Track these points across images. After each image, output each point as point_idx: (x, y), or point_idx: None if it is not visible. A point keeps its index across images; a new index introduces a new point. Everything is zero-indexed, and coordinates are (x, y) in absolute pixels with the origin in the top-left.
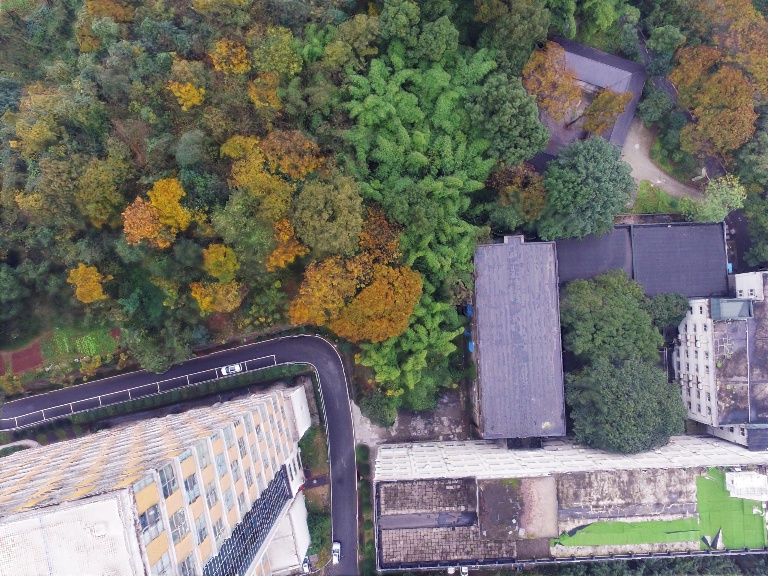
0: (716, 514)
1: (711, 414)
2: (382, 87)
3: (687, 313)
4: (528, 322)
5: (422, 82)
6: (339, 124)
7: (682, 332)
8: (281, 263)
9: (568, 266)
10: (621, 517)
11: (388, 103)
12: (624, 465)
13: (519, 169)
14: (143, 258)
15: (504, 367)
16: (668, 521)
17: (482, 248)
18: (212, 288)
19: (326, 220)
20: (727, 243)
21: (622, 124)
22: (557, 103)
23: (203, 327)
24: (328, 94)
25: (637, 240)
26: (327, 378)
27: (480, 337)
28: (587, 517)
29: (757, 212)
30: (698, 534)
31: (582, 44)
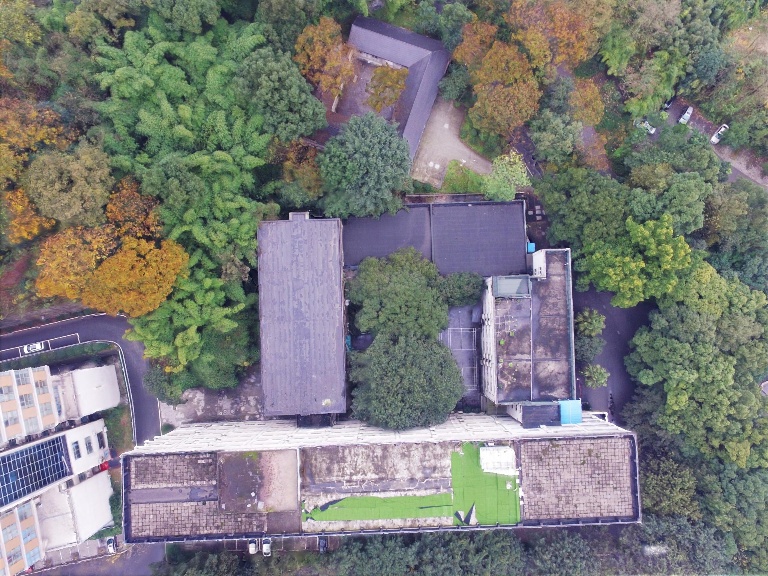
0: (470, 489)
1: None
2: (139, 59)
3: (486, 292)
4: (311, 299)
5: (186, 55)
6: (85, 95)
7: (484, 312)
8: (22, 234)
9: (367, 245)
10: (374, 492)
11: (145, 75)
12: (380, 440)
13: (292, 144)
14: None
15: (285, 344)
16: (421, 496)
17: (266, 224)
18: None
19: (59, 190)
20: (538, 223)
21: (423, 103)
22: (328, 78)
23: None
24: (79, 65)
25: (437, 219)
26: (132, 357)
27: (262, 314)
28: (340, 492)
29: (543, 190)
30: (451, 509)
31: (387, 23)
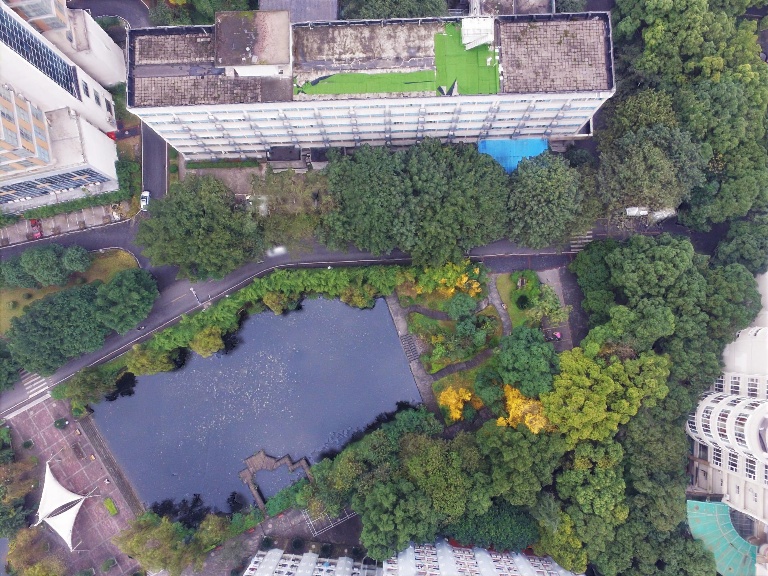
0: (452, 67)
1: None
2: None
3: None
4: None
5: None
6: None
7: None
8: None
9: None
10: (362, 69)
11: None
12: None
13: None
14: None
15: None
16: (406, 72)
17: None
18: None
19: None
20: None
21: None
22: None
23: None
24: None
25: None
26: None
27: None
28: (330, 69)
29: None
30: (434, 84)
31: None
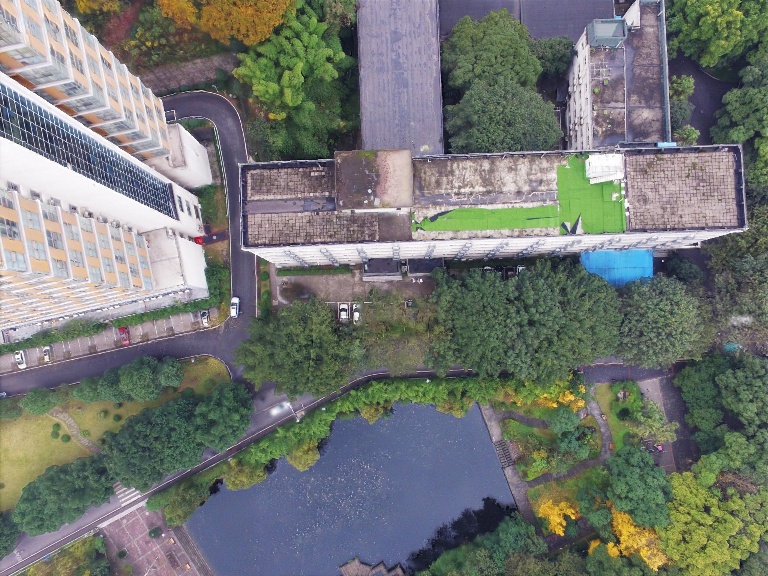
0: (576, 201)
1: (589, 140)
2: None
3: (574, 60)
4: (408, 50)
5: None
6: None
7: (571, 83)
8: None
9: (457, 15)
10: (482, 204)
11: None
12: None
13: None
14: None
15: (384, 93)
16: (528, 208)
17: None
18: None
19: None
20: (621, 6)
21: None
22: None
23: None
24: None
25: None
26: (226, 134)
27: (361, 64)
28: (449, 204)
29: None
30: (558, 220)
31: None
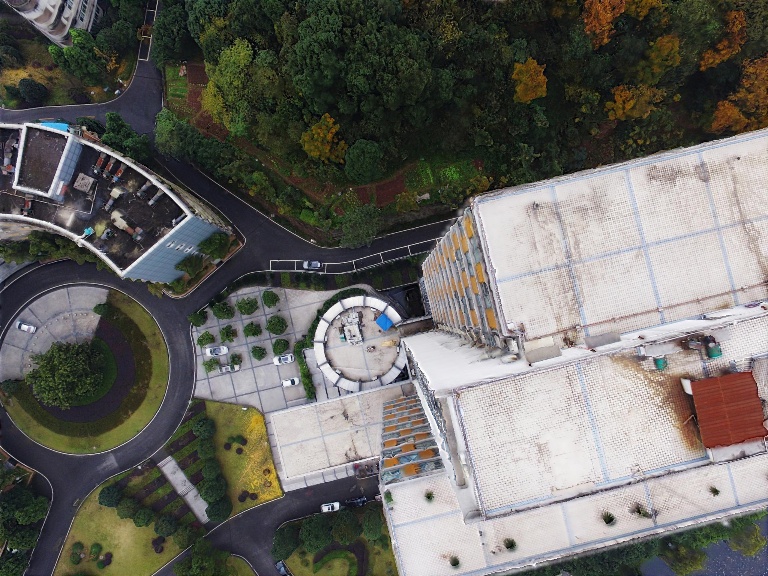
0: None
1: None
2: None
3: None
4: None
5: None
6: None
7: None
8: None
9: None
10: None
11: None
12: None
13: None
14: (585, 54)
15: None
16: None
17: None
18: (639, 90)
19: None
20: None
21: None
22: None
23: (585, 149)
24: None
25: None
26: None
27: None
28: None
29: None
30: None
31: None
